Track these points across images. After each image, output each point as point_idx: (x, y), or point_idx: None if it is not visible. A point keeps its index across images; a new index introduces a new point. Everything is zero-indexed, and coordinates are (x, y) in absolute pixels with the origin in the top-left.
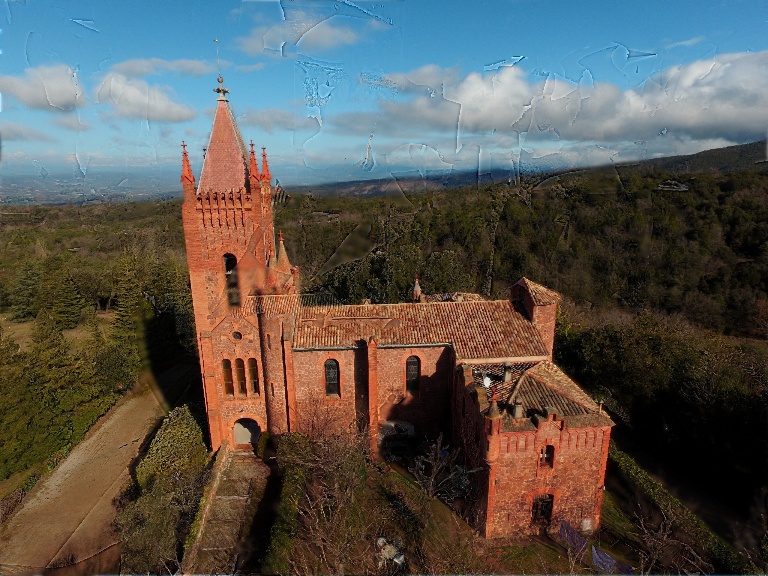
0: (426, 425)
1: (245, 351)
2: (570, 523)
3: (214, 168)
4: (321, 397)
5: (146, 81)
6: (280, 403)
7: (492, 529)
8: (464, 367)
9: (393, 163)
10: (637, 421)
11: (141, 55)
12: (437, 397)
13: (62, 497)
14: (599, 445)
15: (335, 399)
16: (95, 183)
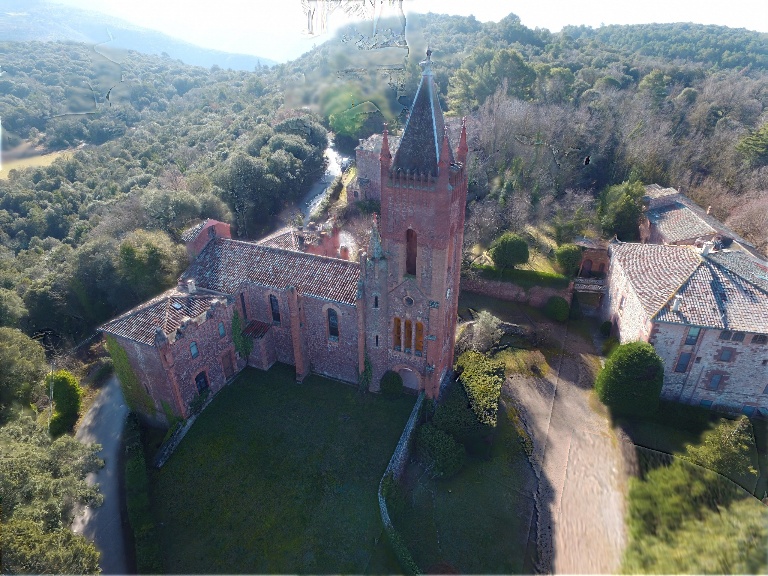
0: None
1: None
2: None
3: None
4: None
5: None
6: None
7: None
8: (310, 242)
9: None
10: None
11: None
12: None
13: None
14: None
15: None
16: None
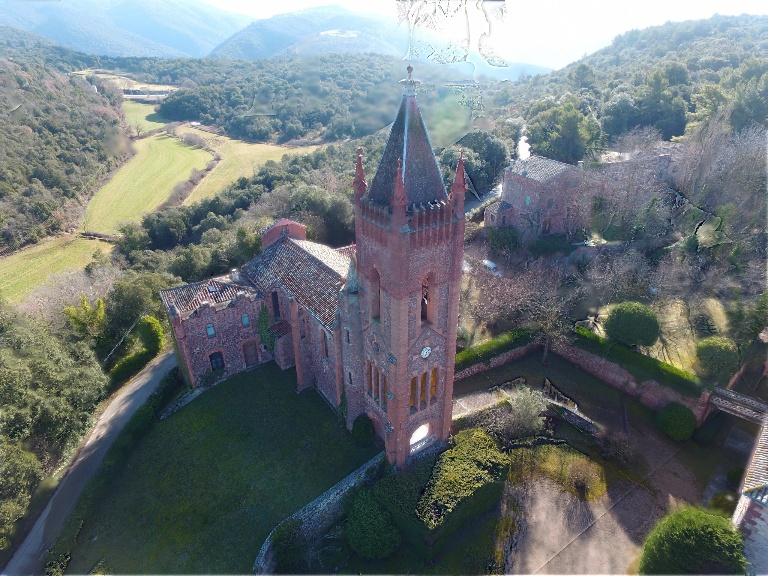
0: None
1: None
2: None
3: None
4: None
5: None
6: None
7: None
8: None
9: None
10: None
11: None
12: None
13: None
14: None
15: None
16: None
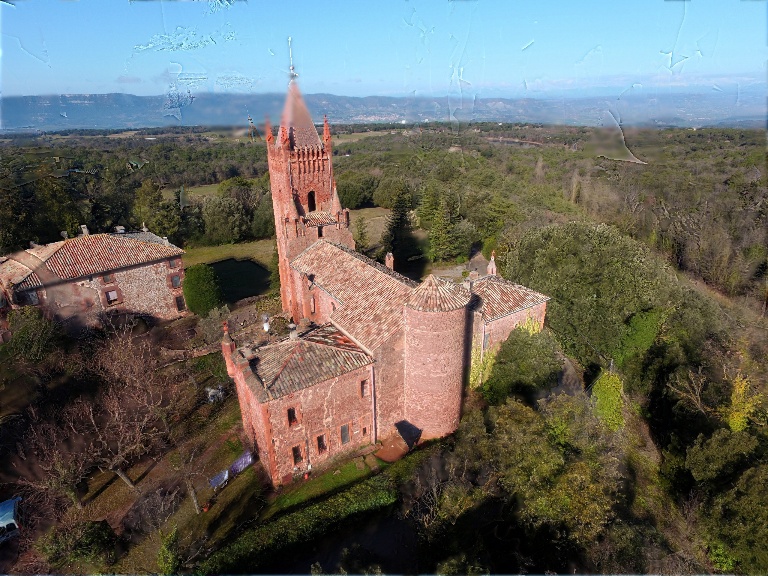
0: None
1: None
2: None
3: None
4: None
5: (467, 34)
6: None
7: (245, 427)
8: None
9: (745, 106)
10: None
11: (467, 11)
12: None
13: None
14: (261, 414)
15: None
16: (446, 122)
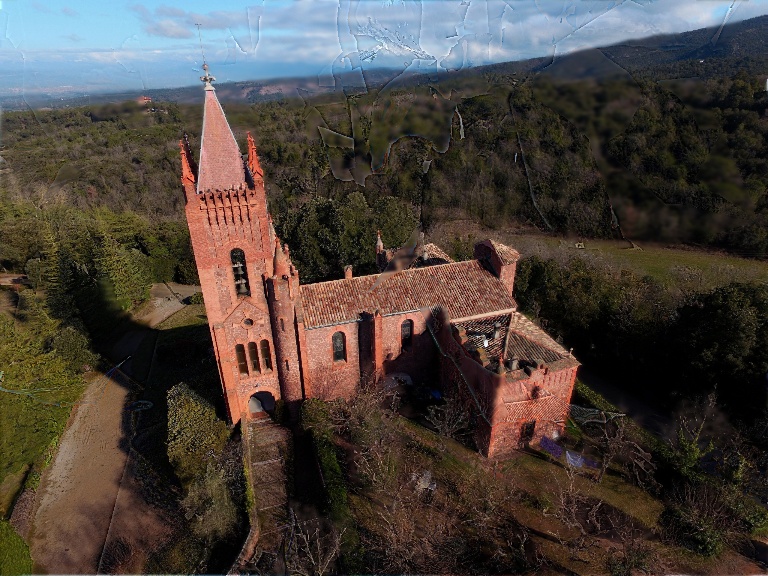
0: (417, 373)
1: (257, 335)
2: (545, 435)
3: (211, 164)
4: (330, 364)
5: (19, 4)
6: (295, 375)
7: (493, 451)
8: (459, 329)
9: (316, 96)
10: (569, 342)
11: None
12: (426, 349)
13: (78, 487)
14: (569, 380)
15: (342, 364)
16: None
